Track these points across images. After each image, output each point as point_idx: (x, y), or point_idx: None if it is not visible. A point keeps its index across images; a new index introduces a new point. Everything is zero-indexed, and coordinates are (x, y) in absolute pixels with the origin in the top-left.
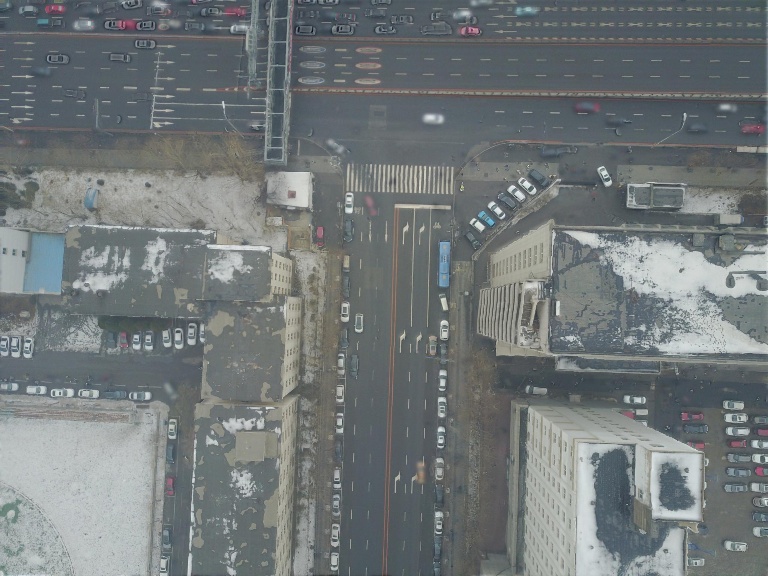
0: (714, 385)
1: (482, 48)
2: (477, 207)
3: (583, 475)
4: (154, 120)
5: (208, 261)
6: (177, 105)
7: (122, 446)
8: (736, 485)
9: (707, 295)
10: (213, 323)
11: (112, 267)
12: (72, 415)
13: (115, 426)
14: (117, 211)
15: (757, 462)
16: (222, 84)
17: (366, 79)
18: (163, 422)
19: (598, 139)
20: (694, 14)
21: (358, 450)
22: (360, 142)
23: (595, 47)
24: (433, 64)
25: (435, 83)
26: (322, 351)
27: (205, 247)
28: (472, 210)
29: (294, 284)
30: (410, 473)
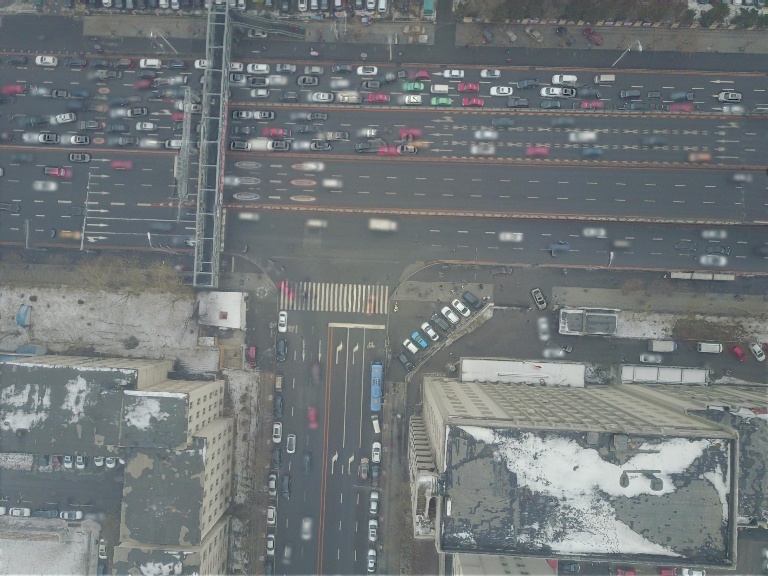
0: None
1: (417, 167)
2: (411, 327)
3: None
4: (88, 235)
5: (125, 407)
6: (111, 220)
7: (53, 565)
8: None
9: (601, 494)
10: (132, 465)
11: (32, 406)
12: (3, 534)
13: (46, 545)
14: (49, 328)
15: None
16: (157, 199)
17: (301, 196)
18: (94, 542)
19: (533, 260)
20: (630, 136)
21: (289, 571)
22: (294, 260)
23: (531, 168)
24: (368, 182)
25: (370, 201)
26: (254, 471)
27: (122, 393)
28: (406, 330)
29: (227, 403)
30: None
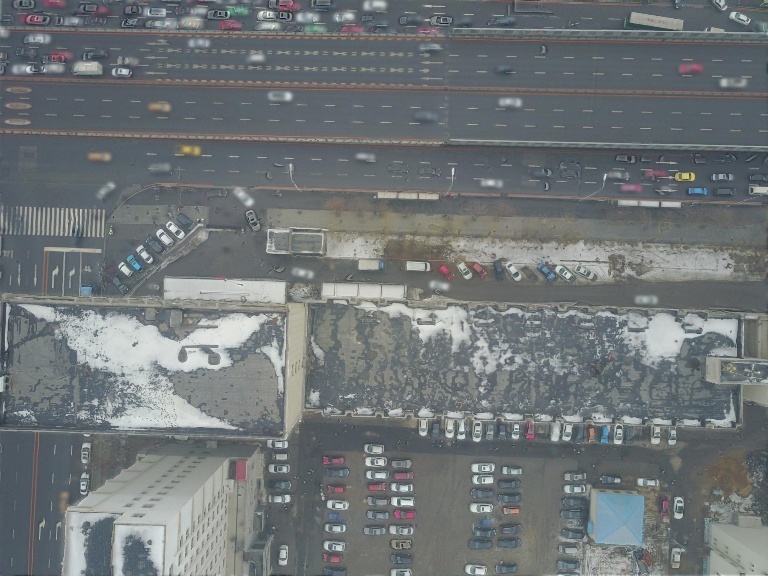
0: (357, 429)
1: (132, 89)
2: (127, 250)
3: (73, 544)
4: None
5: None
6: None
7: None
8: (373, 528)
9: (159, 369)
10: None
11: None
12: None
13: None
14: None
15: (395, 505)
16: None
17: (16, 120)
18: None
19: (249, 182)
20: (340, 58)
21: (3, 497)
22: (10, 184)
23: (244, 90)
24: (84, 105)
25: (85, 125)
26: None
27: None
28: (122, 253)
29: None
30: (55, 519)
